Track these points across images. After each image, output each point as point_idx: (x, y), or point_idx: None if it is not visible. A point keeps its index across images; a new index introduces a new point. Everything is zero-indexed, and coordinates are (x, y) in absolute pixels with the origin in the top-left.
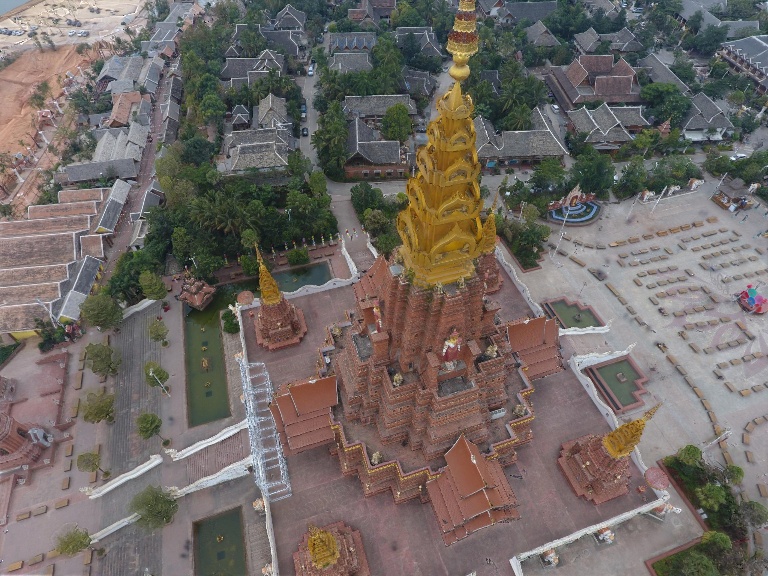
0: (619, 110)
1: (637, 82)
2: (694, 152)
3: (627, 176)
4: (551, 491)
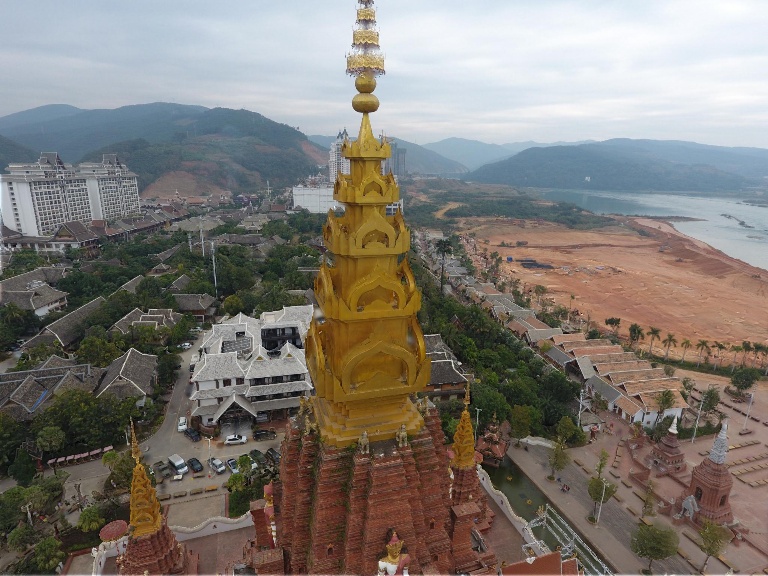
0: None
1: None
2: None
3: None
4: (223, 567)
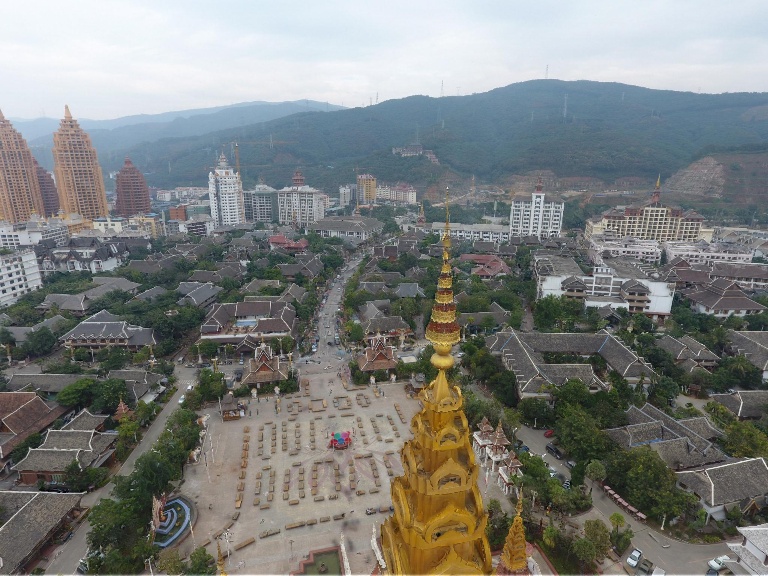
0: (70, 426)
1: (43, 399)
2: (161, 408)
3: (166, 456)
4: None
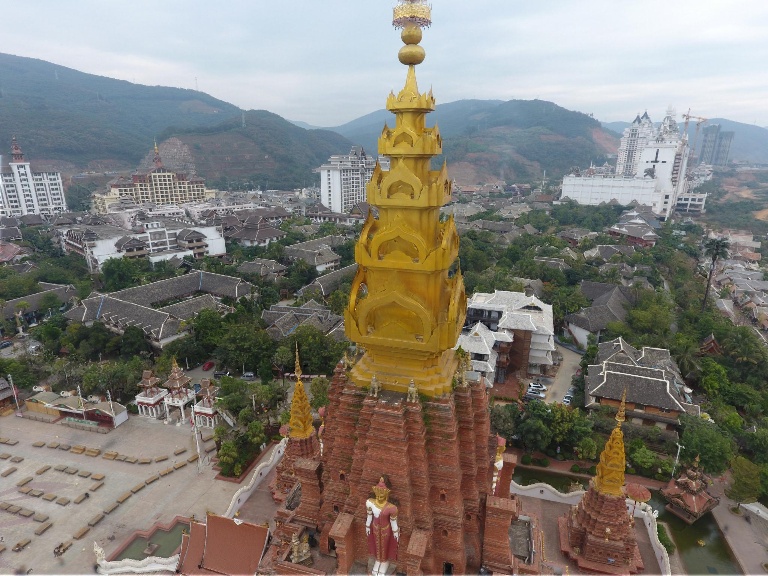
0: None
1: None
2: None
3: None
4: None
